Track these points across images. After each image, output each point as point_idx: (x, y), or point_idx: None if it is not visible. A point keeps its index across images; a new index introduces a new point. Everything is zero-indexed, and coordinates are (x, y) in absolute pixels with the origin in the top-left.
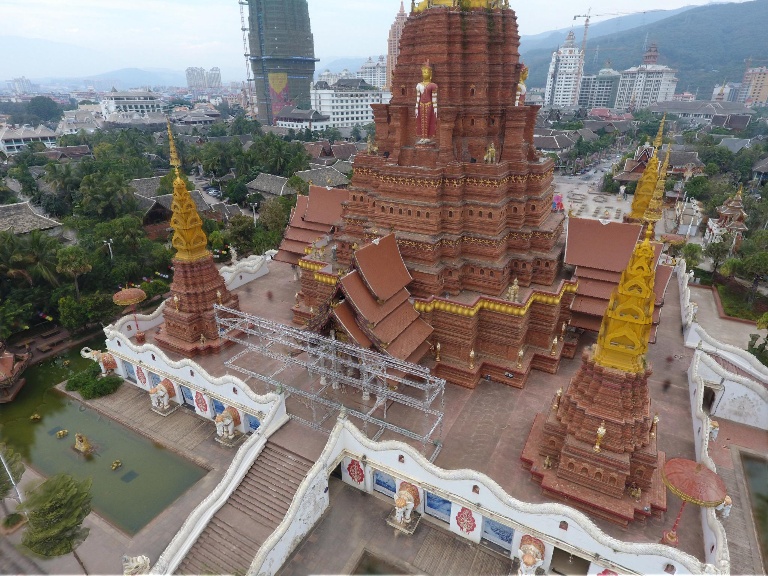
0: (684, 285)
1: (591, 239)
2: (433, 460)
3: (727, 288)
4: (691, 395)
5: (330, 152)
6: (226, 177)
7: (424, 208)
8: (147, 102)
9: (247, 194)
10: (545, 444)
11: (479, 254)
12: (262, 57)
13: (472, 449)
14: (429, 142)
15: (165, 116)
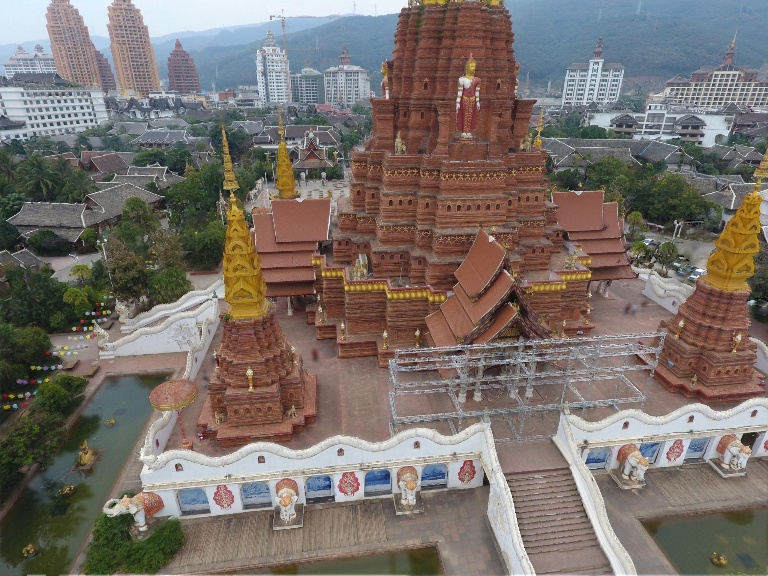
0: None
1: (572, 208)
2: None
3: None
4: (666, 307)
5: (90, 166)
6: None
7: (494, 200)
8: None
9: (22, 234)
10: (684, 367)
11: (528, 236)
12: None
13: None
14: None
15: None
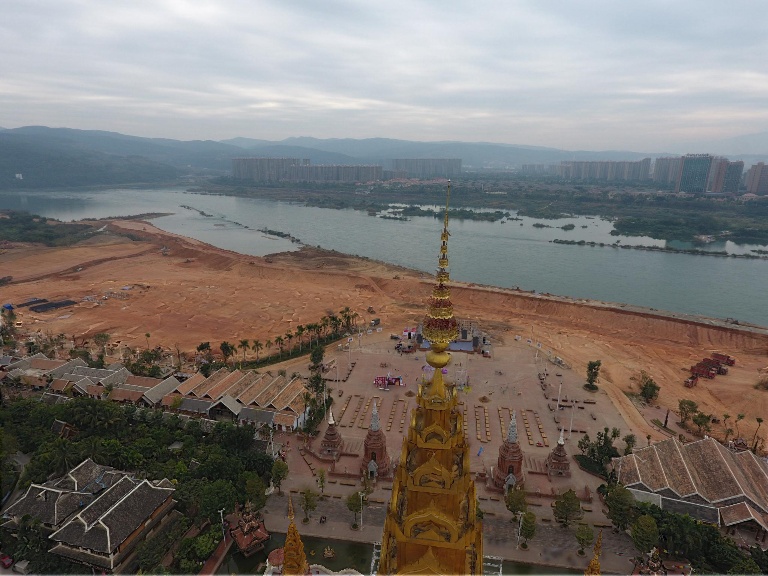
0: None
1: None
2: None
3: None
4: None
5: None
6: None
7: None
8: None
9: None
10: None
11: None
12: None
13: None
14: None
15: None
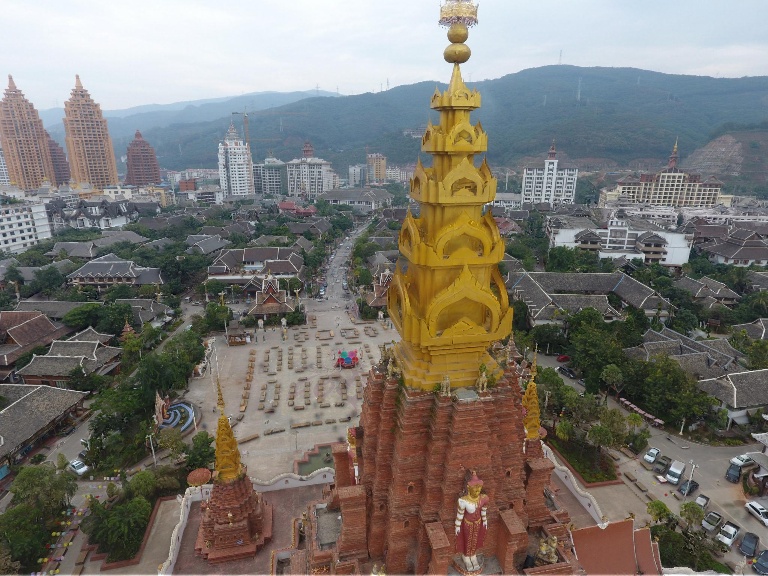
0: (575, 484)
1: (597, 548)
2: None
3: (561, 444)
4: None
5: (6, 339)
6: None
7: None
8: None
9: None
10: None
11: None
12: None
13: None
14: (476, 557)
15: None
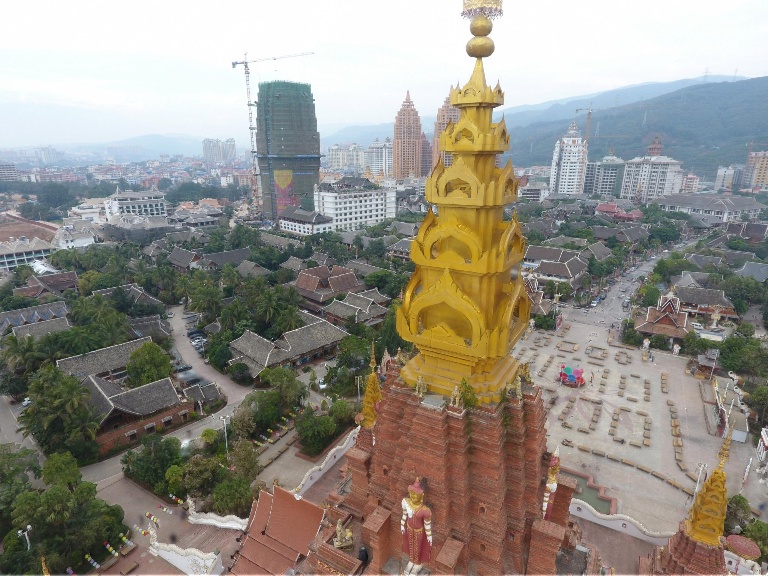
0: None
1: None
2: None
3: None
4: None
5: (327, 284)
6: (211, 326)
7: None
8: (151, 201)
9: (229, 360)
10: None
11: None
12: (268, 155)
13: None
14: (421, 569)
15: (166, 220)
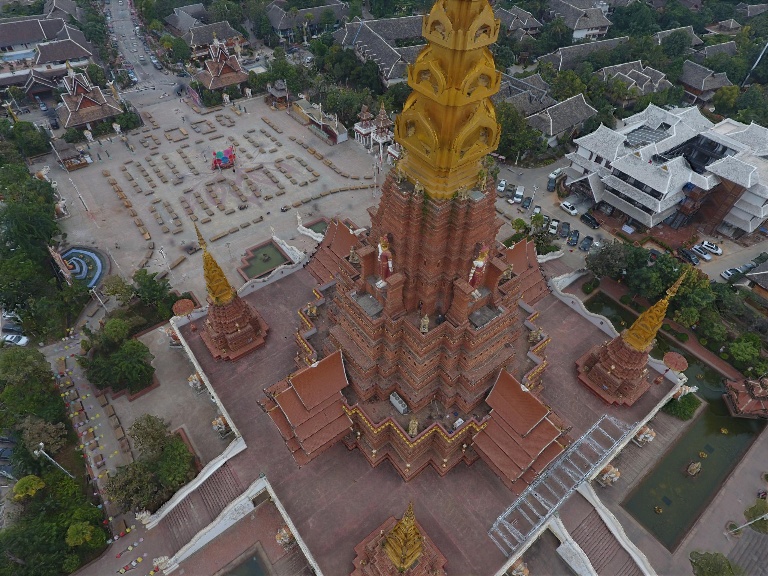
0: None
1: (509, 261)
2: (599, 445)
3: None
4: (566, 302)
5: None
6: None
7: None
8: None
9: None
10: None
11: None
12: None
13: (592, 422)
14: None
15: None
